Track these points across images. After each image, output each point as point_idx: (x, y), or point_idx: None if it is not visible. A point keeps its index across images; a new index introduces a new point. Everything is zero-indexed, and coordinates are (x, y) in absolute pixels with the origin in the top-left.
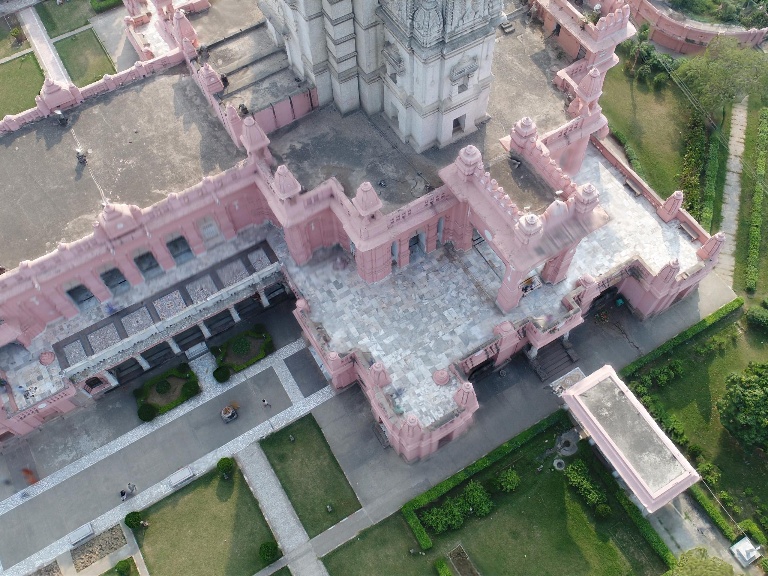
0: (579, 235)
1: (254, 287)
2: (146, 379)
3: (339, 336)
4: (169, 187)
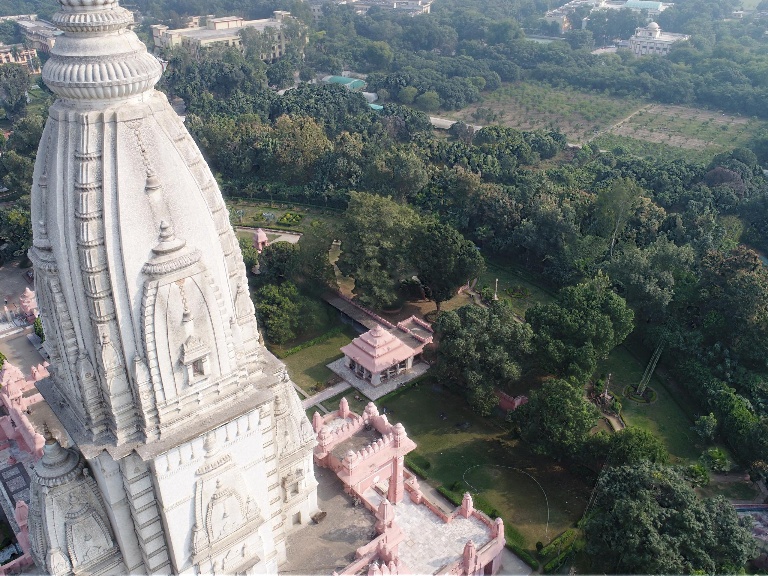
0: None
1: None
2: (8, 524)
3: None
4: None
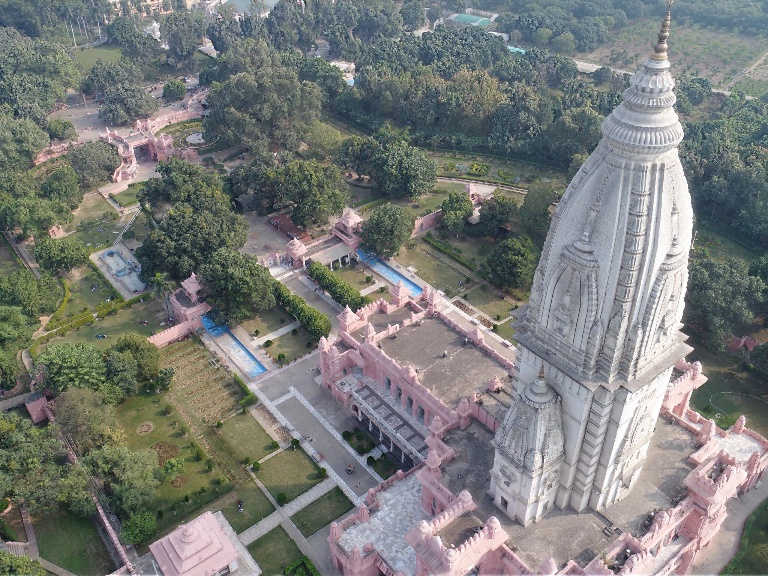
0: (433, 566)
1: (411, 454)
2: (365, 432)
3: (387, 496)
4: (438, 390)
